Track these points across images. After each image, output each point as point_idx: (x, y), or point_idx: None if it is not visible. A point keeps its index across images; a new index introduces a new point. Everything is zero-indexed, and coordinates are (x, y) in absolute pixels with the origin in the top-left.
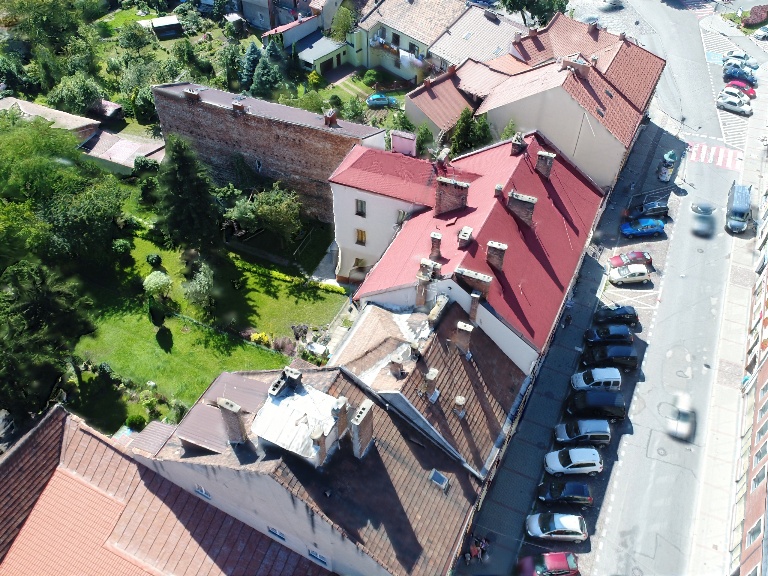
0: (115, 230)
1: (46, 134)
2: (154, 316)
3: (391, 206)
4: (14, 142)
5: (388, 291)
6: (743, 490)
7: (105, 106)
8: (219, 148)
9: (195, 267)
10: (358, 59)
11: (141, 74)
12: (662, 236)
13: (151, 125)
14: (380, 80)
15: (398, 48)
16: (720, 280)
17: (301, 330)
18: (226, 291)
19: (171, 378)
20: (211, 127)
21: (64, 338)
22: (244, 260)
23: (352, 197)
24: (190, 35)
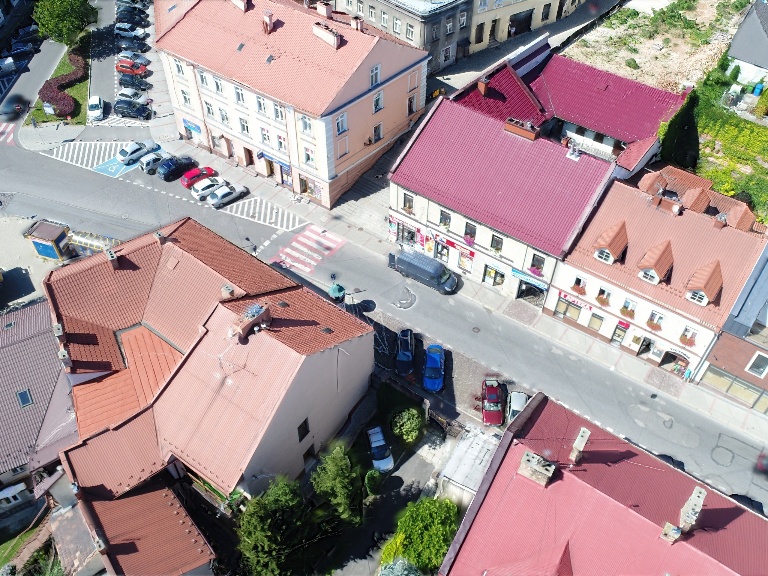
0: None
1: None
2: None
3: None
4: None
5: None
6: None
7: None
8: None
9: None
10: None
11: None
12: (447, 355)
13: None
14: None
15: None
16: (525, 333)
17: None
18: None
19: None
20: None
21: None
22: None
23: None
24: None
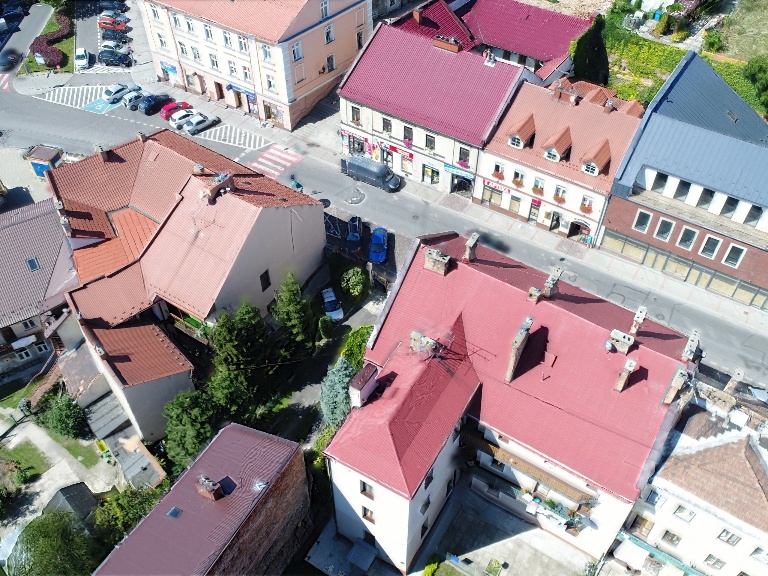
0: None
1: None
2: None
3: None
4: None
5: None
6: (705, 277)
7: None
8: None
9: None
10: None
11: None
12: (390, 236)
13: None
14: None
15: None
16: (457, 218)
17: None
18: None
19: None
20: None
21: None
22: None
23: None
24: None
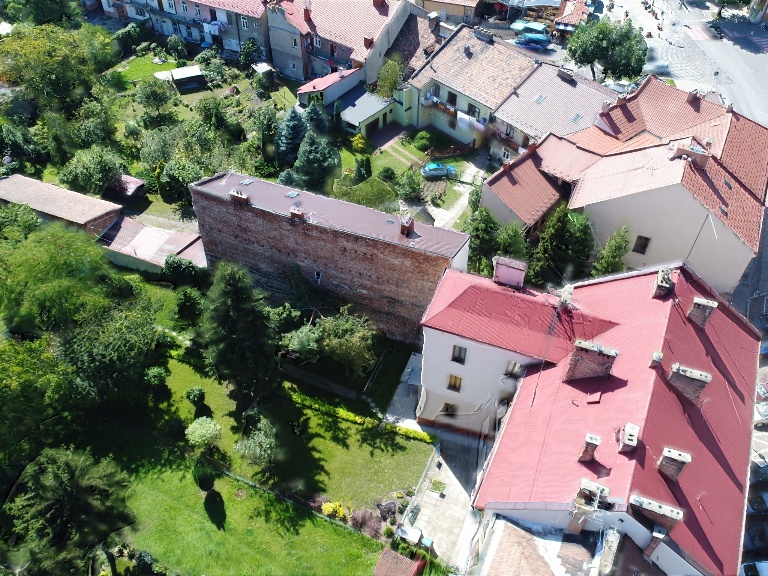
0: (147, 355)
1: (65, 247)
2: (203, 484)
3: (500, 356)
4: (27, 262)
5: (528, 509)
6: None
7: (125, 183)
8: (270, 255)
9: (251, 420)
10: (407, 118)
11: (166, 145)
12: None
13: (178, 203)
14: (434, 144)
15: (455, 109)
16: None
17: (390, 511)
18: (285, 439)
19: (227, 569)
20: (261, 233)
21: (98, 541)
22: (303, 393)
23: (449, 342)
24: (214, 87)
